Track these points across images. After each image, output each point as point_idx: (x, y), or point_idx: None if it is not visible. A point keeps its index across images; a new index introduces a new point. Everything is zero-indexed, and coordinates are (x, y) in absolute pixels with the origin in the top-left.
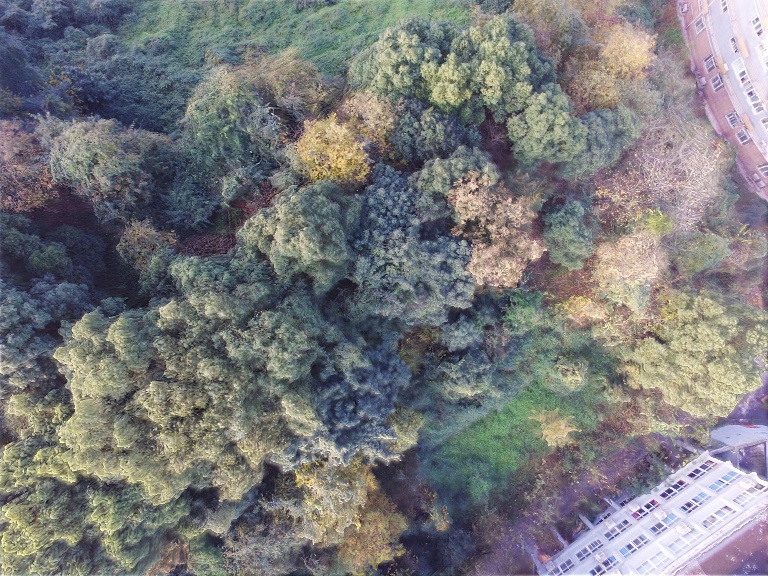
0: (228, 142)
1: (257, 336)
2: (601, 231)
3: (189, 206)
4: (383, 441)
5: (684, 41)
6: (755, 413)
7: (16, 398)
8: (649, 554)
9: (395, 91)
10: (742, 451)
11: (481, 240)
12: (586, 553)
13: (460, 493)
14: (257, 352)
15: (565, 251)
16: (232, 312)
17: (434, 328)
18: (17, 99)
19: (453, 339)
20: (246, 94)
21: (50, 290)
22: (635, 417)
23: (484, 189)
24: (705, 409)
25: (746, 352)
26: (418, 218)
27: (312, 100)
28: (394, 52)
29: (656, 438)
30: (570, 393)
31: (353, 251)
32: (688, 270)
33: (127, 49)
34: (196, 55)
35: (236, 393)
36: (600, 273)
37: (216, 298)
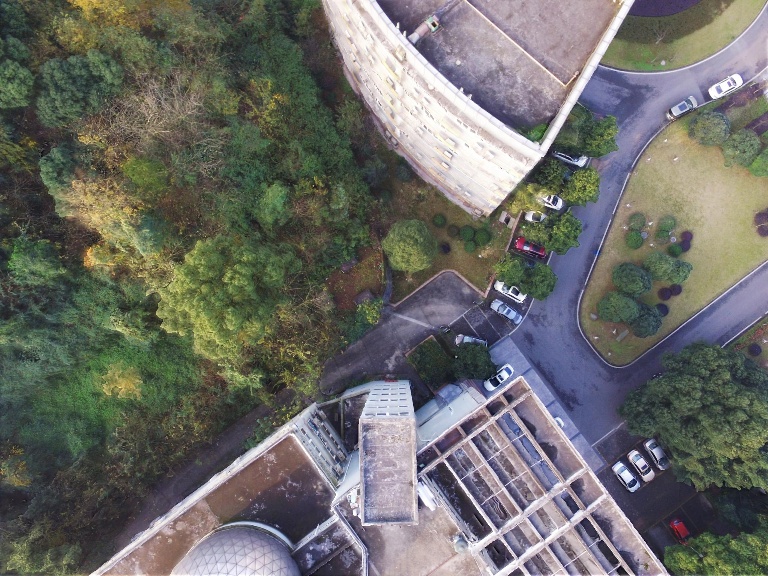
0: None
1: None
2: (93, 178)
3: None
4: None
5: None
6: (401, 368)
7: None
8: None
9: None
10: (348, 402)
11: None
12: None
13: (64, 451)
14: None
15: None
16: None
17: None
18: None
19: None
20: None
21: None
22: (222, 369)
23: None
24: (215, 352)
25: (222, 291)
26: None
27: None
28: None
29: None
30: (150, 347)
31: None
32: (266, 222)
33: None
34: None
35: None
36: None
37: None
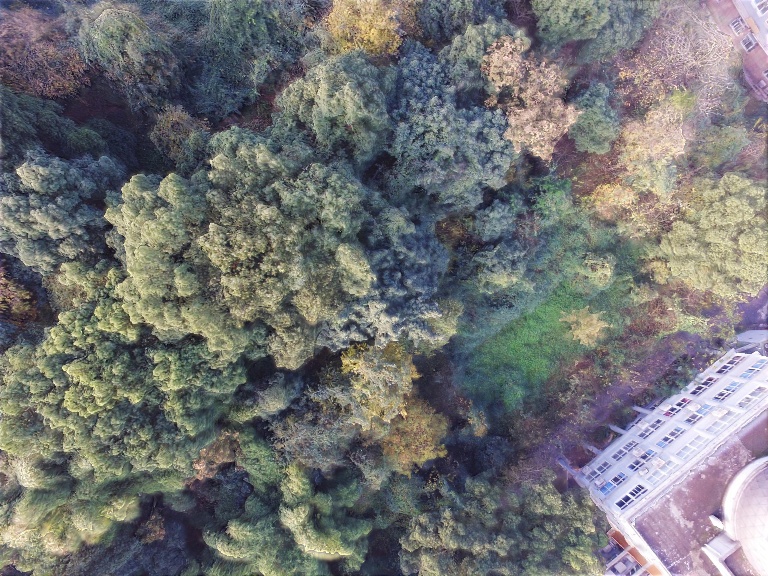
0: (256, 30)
1: (310, 183)
2: (626, 114)
3: (219, 98)
4: (427, 322)
5: None
6: None
7: (67, 264)
8: (687, 439)
9: None
10: (767, 346)
11: (516, 107)
12: (622, 453)
13: (494, 403)
14: (311, 200)
15: (592, 135)
16: (282, 164)
17: (467, 217)
18: (34, 10)
19: (488, 224)
20: None
21: (93, 163)
22: (662, 315)
23: (517, 54)
24: (736, 287)
25: None
26: (454, 85)
27: None
28: None
29: (682, 340)
30: (598, 293)
31: (391, 120)
32: None
33: None
34: None
35: (294, 237)
36: (627, 156)
37: None
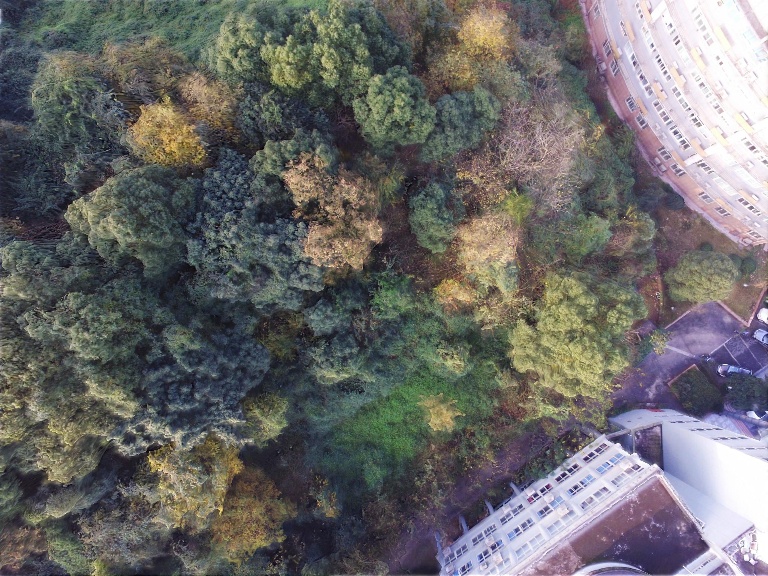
0: (75, 129)
1: (57, 317)
2: (464, 213)
3: (40, 193)
4: (236, 425)
5: (586, 26)
6: (662, 397)
7: None
8: (529, 536)
9: (236, 75)
10: (638, 434)
11: (318, 221)
12: (480, 538)
13: (356, 480)
14: (59, 333)
15: (429, 234)
16: (37, 294)
17: (298, 313)
18: None
19: (313, 323)
20: (85, 80)
21: None
22: (526, 401)
23: (316, 170)
24: (575, 390)
25: (606, 331)
26: (250, 200)
27: (159, 86)
28: (233, 36)
29: None
30: (459, 378)
31: (185, 234)
32: (575, 253)
33: (23, 43)
34: (95, 48)
35: (32, 373)
36: (465, 255)
37: (19, 280)
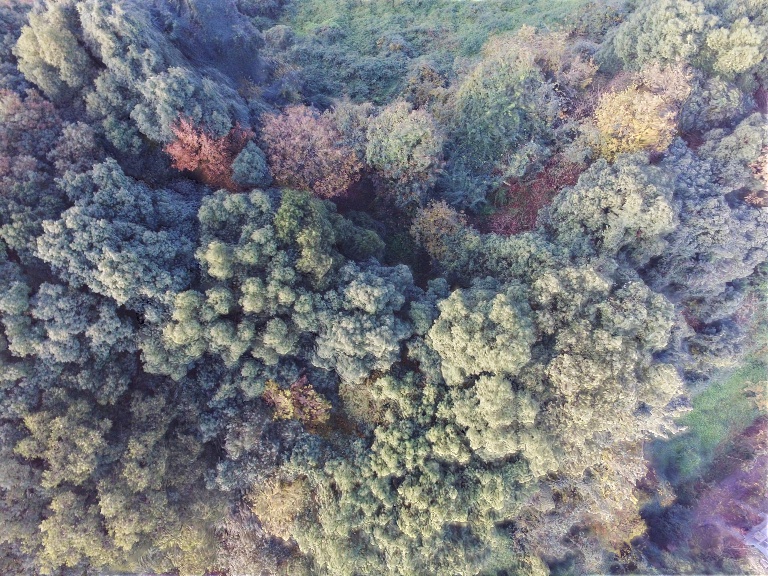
0: (507, 120)
1: (641, 306)
2: None
3: (466, 187)
4: None
5: None
6: None
7: (386, 381)
8: None
9: (681, 61)
10: None
11: None
12: None
13: (668, 468)
14: (639, 322)
15: None
16: None
17: (692, 300)
18: (259, 88)
19: (720, 310)
20: (536, 70)
21: (394, 272)
22: None
23: None
24: None
25: None
26: (730, 186)
27: (586, 75)
28: (681, 22)
29: None
30: None
31: None
32: None
33: (303, 39)
34: (366, 43)
35: None
36: None
37: None
